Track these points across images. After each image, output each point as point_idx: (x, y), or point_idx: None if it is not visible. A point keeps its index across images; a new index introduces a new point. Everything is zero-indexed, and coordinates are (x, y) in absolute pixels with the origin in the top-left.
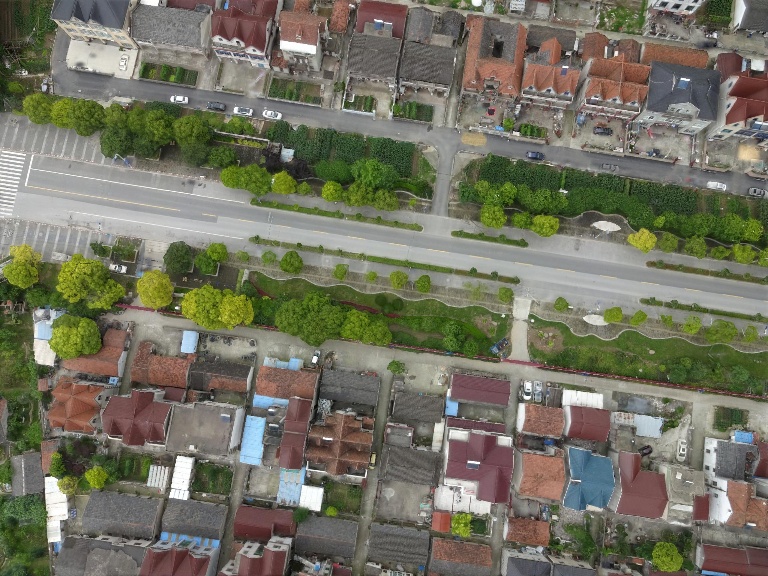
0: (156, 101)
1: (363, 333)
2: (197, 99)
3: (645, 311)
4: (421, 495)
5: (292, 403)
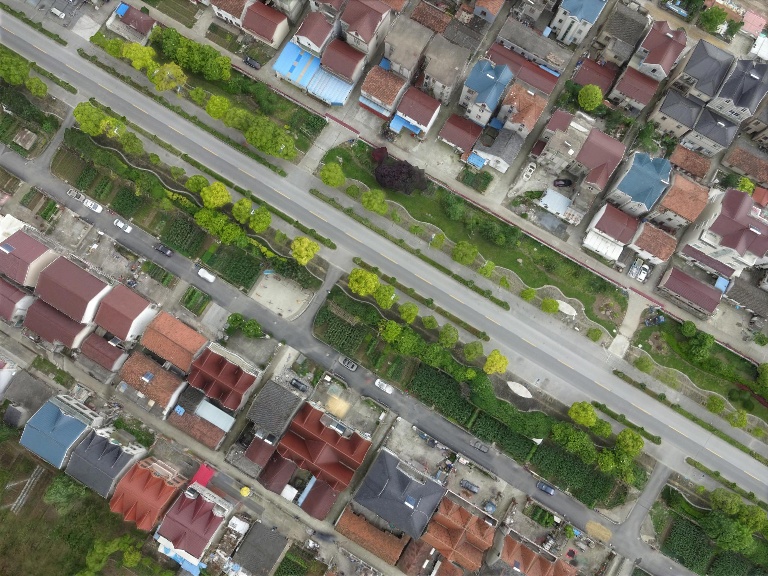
0: None
1: None
2: None
3: (509, 298)
4: None
5: None
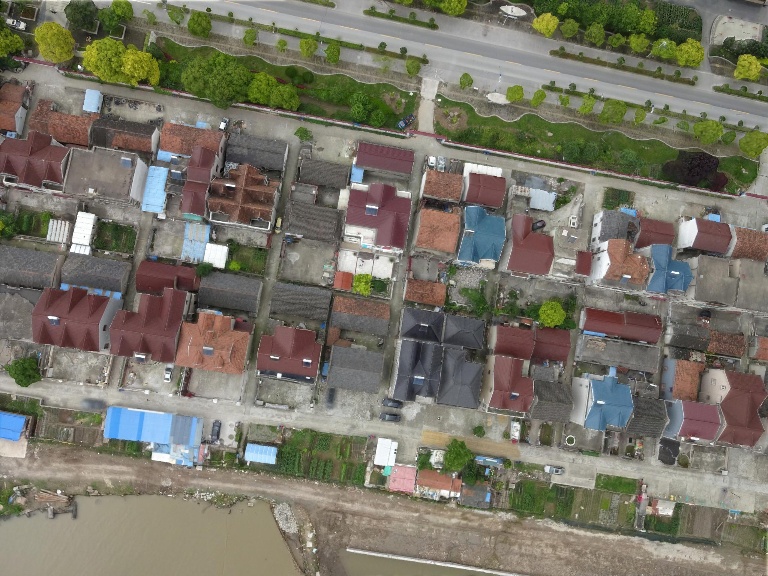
0: None
1: (270, 92)
2: None
3: (546, 97)
4: (325, 260)
5: (195, 152)
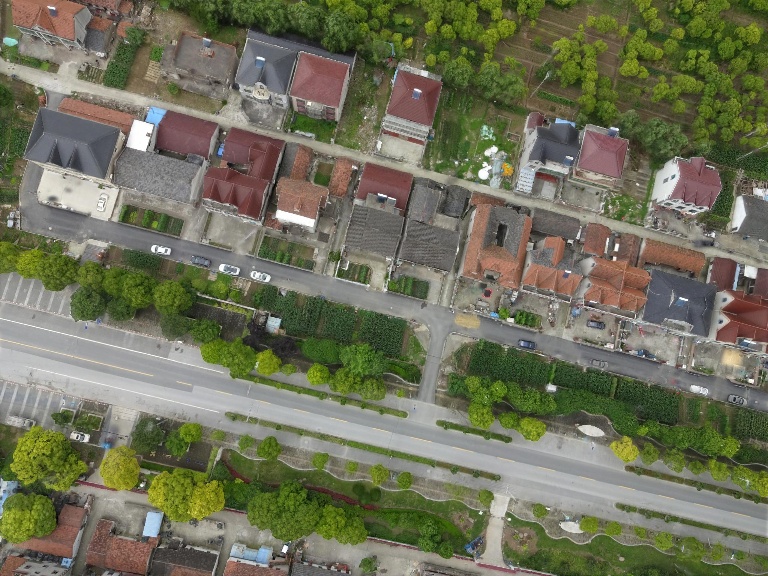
0: (135, 251)
1: (338, 535)
2: (180, 250)
3: (619, 516)
4: None
5: None
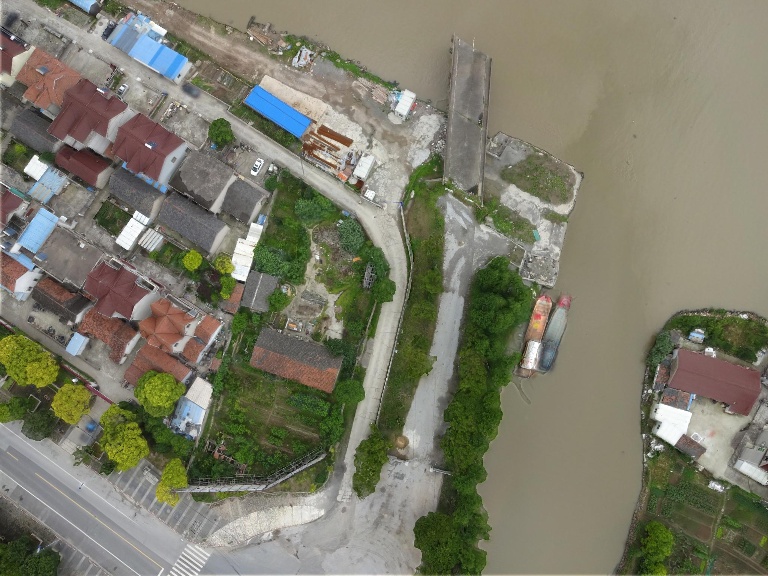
0: None
1: None
2: None
3: None
4: None
5: None
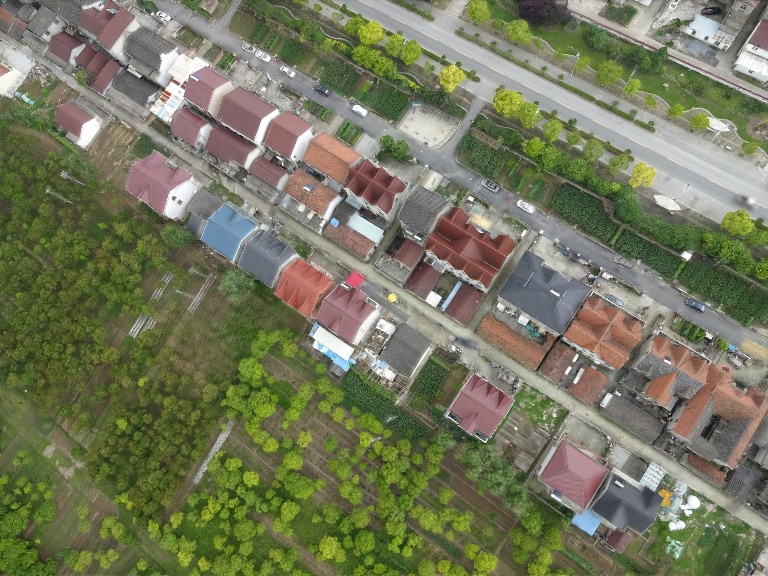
0: None
1: None
2: None
3: (654, 122)
4: None
5: None
